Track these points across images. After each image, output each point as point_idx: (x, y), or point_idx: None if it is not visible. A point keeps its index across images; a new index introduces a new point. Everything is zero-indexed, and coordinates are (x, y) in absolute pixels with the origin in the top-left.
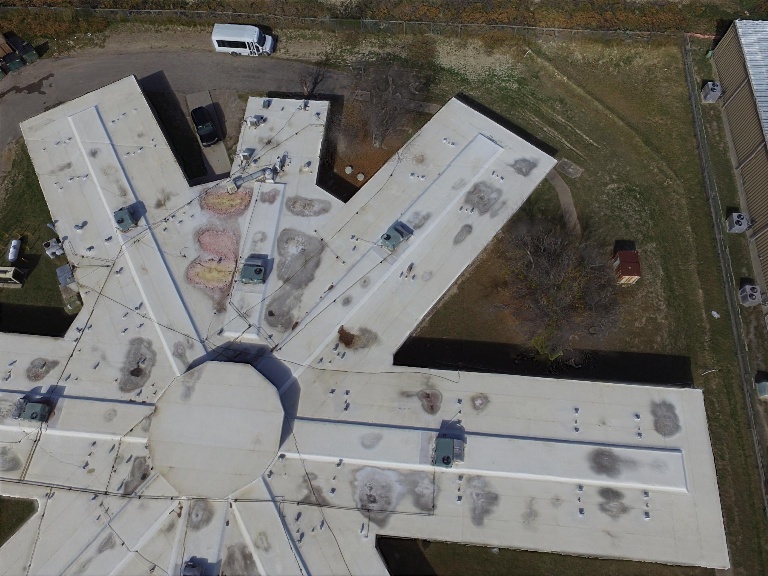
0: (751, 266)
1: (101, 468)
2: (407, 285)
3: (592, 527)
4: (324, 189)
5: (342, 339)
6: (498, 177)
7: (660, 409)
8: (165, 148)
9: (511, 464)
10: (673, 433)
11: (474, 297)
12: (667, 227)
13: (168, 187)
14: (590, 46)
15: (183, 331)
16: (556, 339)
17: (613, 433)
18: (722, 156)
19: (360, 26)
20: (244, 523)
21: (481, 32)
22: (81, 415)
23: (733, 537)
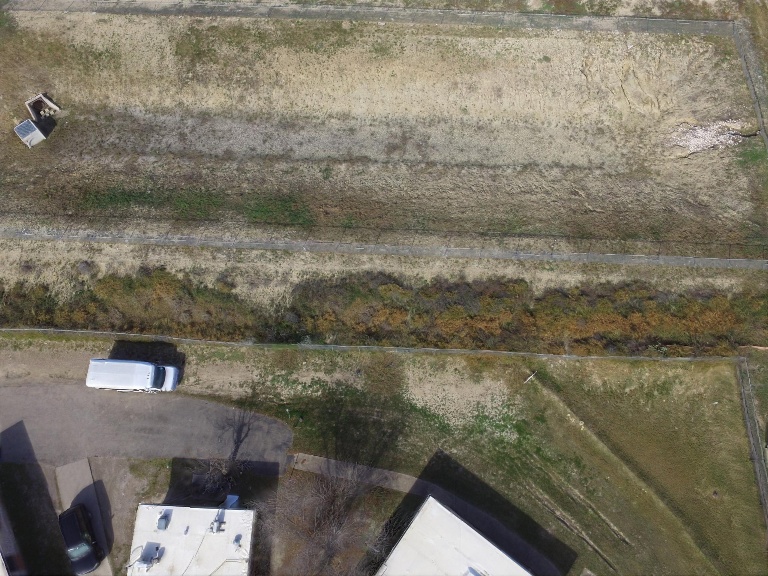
0: None
1: None
2: None
3: None
4: None
5: None
6: None
7: None
8: None
9: None
10: None
11: None
12: None
13: None
14: (613, 366)
15: None
16: None
17: None
18: None
19: (297, 346)
20: None
21: (464, 352)
22: None
23: None
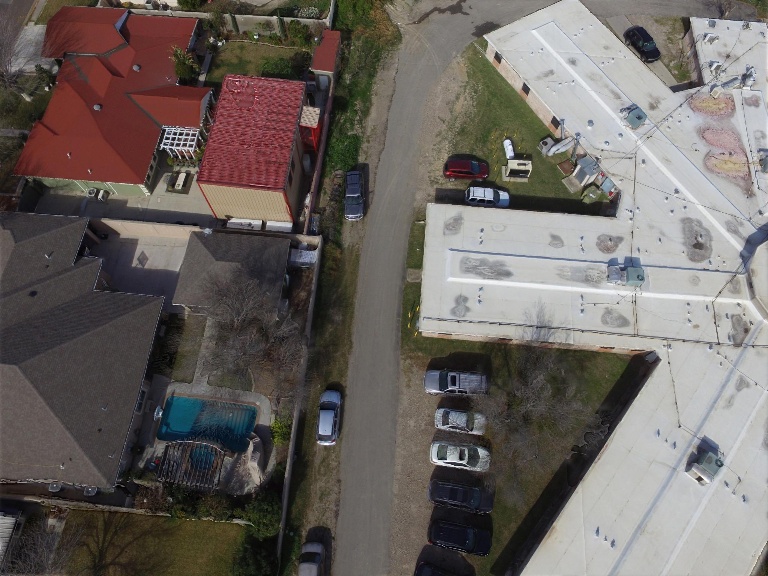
0: None
1: (704, 324)
2: None
3: None
4: None
5: None
6: None
7: None
8: (635, 59)
9: None
10: None
11: None
12: None
13: (654, 92)
14: None
15: (728, 212)
16: None
17: None
18: None
19: None
20: None
21: None
22: (668, 280)
23: None
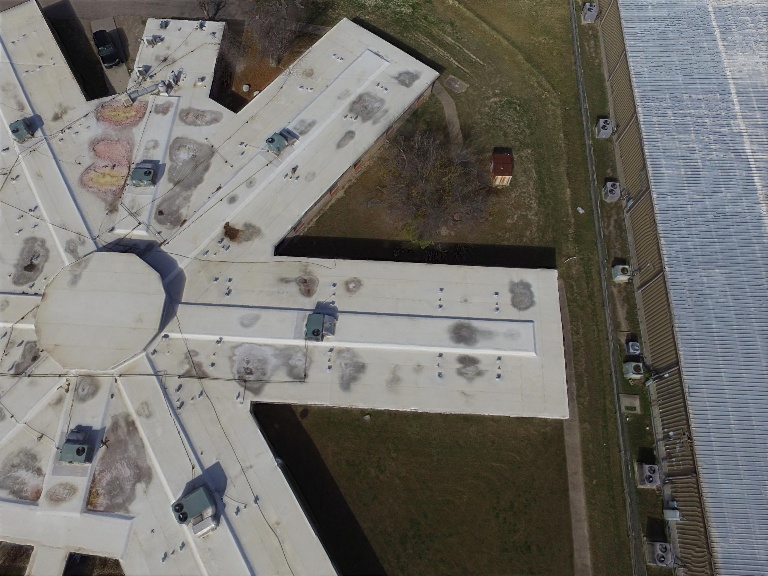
0: (615, 167)
1: None
2: (291, 185)
3: (448, 387)
4: (217, 101)
5: (227, 234)
6: (382, 88)
7: (517, 287)
8: (64, 66)
9: (378, 336)
10: (527, 307)
11: (360, 200)
12: (542, 135)
13: (65, 102)
14: None
15: (75, 230)
16: (423, 226)
17: (473, 308)
18: (596, 71)
19: None
20: (127, 395)
21: None
22: None
23: (581, 398)
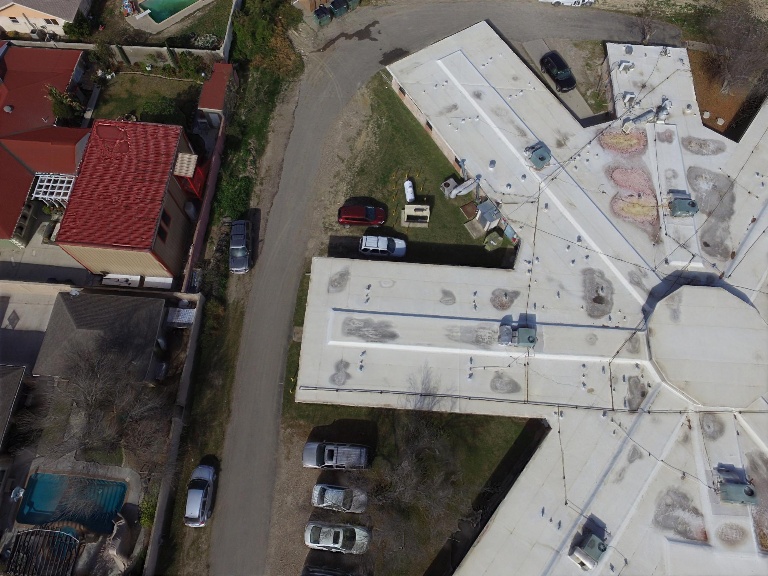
0: None
1: (599, 388)
2: None
3: None
4: (713, 130)
5: None
6: None
7: None
8: (545, 91)
9: None
10: None
11: None
12: None
13: (563, 128)
14: None
15: (632, 261)
16: None
17: None
18: None
19: None
20: (755, 432)
21: None
22: (564, 340)
23: None
